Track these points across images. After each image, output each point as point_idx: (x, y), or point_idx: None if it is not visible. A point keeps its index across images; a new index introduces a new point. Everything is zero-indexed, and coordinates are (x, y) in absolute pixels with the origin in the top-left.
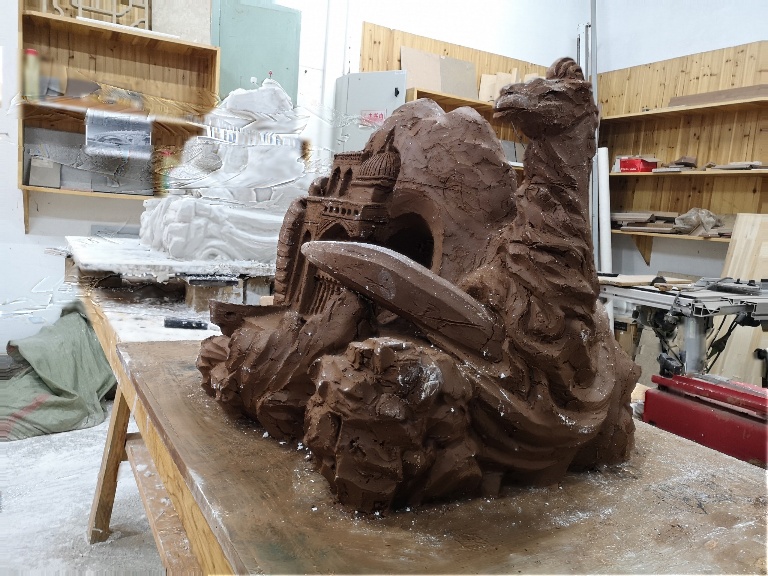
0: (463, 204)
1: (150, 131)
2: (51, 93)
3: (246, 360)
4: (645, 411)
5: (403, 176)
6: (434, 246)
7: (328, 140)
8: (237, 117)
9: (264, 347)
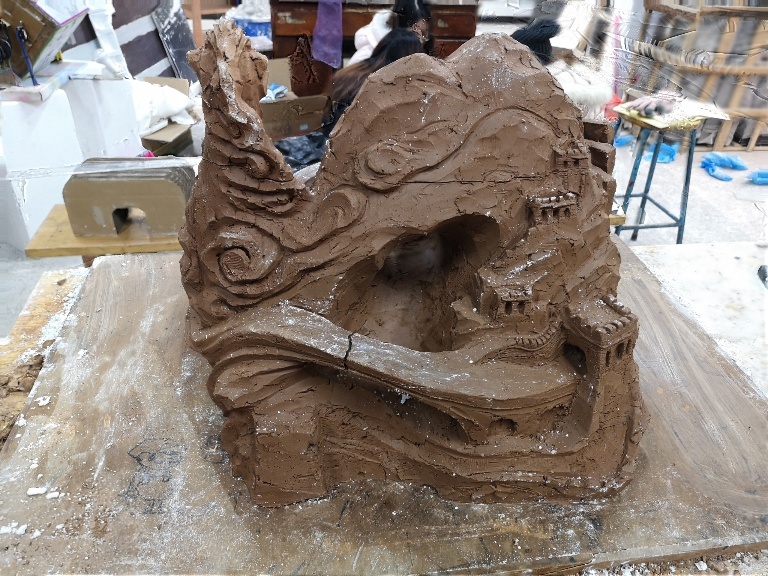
0: None
1: (572, 40)
2: (511, 8)
3: None
4: None
5: None
6: None
7: None
8: (669, 26)
9: None
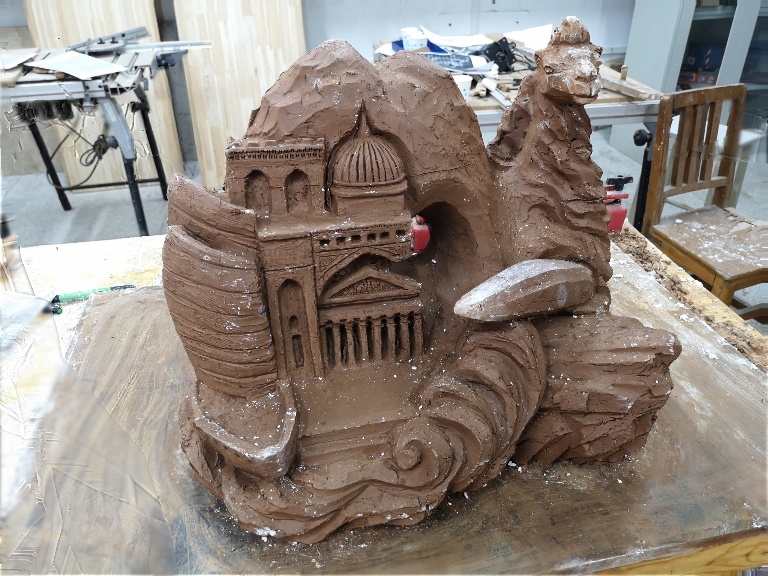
0: (481, 175)
1: None
2: None
3: (482, 456)
4: (416, 245)
5: (422, 167)
6: (472, 227)
7: (3, 95)
8: None
9: (490, 430)
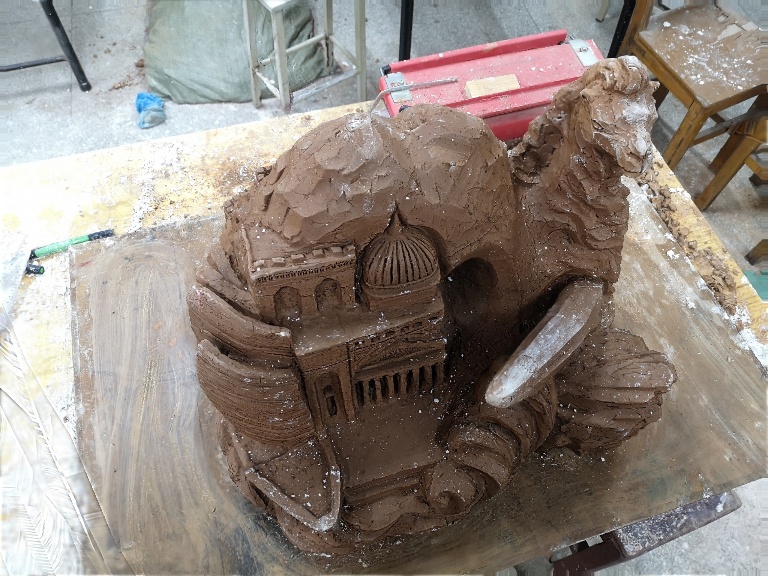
0: None
1: None
2: None
3: None
4: None
5: (454, 248)
6: (494, 268)
7: None
8: (4, 420)
9: (508, 471)
